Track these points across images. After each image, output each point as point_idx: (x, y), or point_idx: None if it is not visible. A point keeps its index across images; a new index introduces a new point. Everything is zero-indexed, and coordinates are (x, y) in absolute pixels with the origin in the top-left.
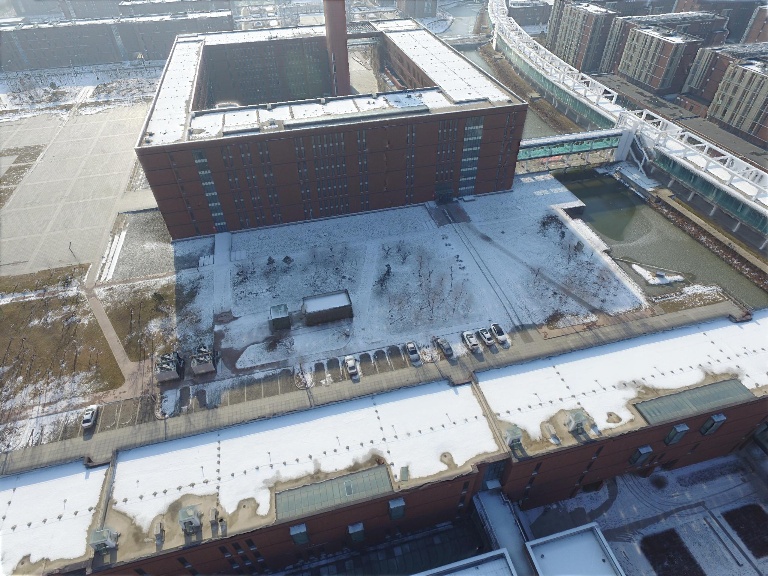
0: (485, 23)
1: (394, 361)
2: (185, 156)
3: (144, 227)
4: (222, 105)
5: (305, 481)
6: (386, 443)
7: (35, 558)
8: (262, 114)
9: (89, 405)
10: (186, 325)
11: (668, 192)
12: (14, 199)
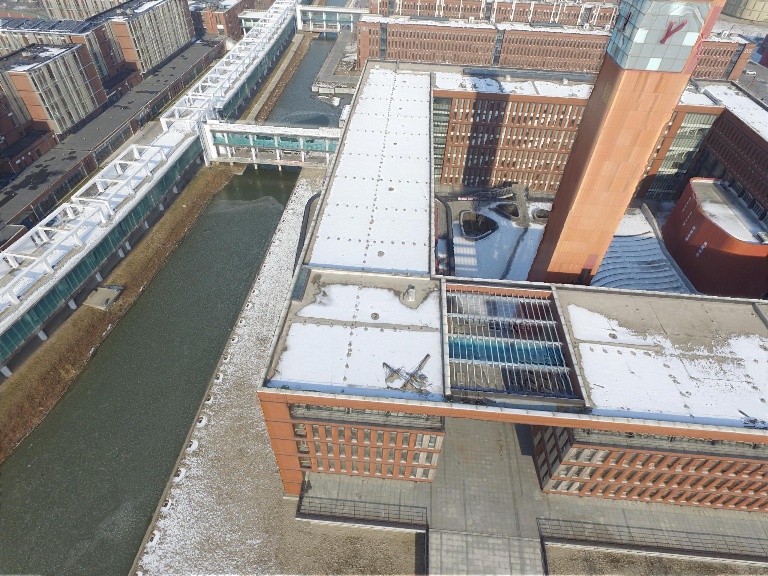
0: None
1: None
2: None
3: None
4: (762, 247)
5: None
6: None
7: None
8: None
9: None
10: None
11: (239, 121)
12: None
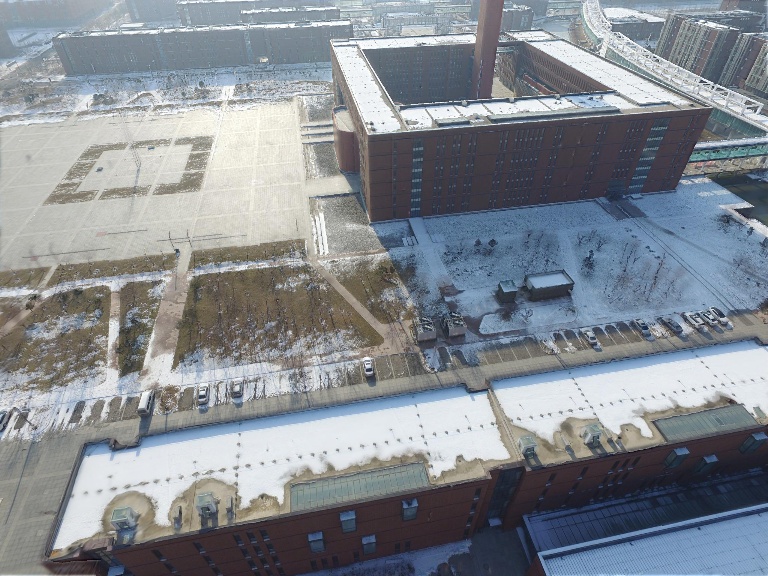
0: (581, 38)
1: (627, 335)
2: (406, 144)
3: (338, 210)
4: None
5: (671, 413)
6: (727, 387)
7: (468, 458)
8: (461, 110)
9: (361, 357)
10: (418, 295)
11: None
12: (208, 182)
